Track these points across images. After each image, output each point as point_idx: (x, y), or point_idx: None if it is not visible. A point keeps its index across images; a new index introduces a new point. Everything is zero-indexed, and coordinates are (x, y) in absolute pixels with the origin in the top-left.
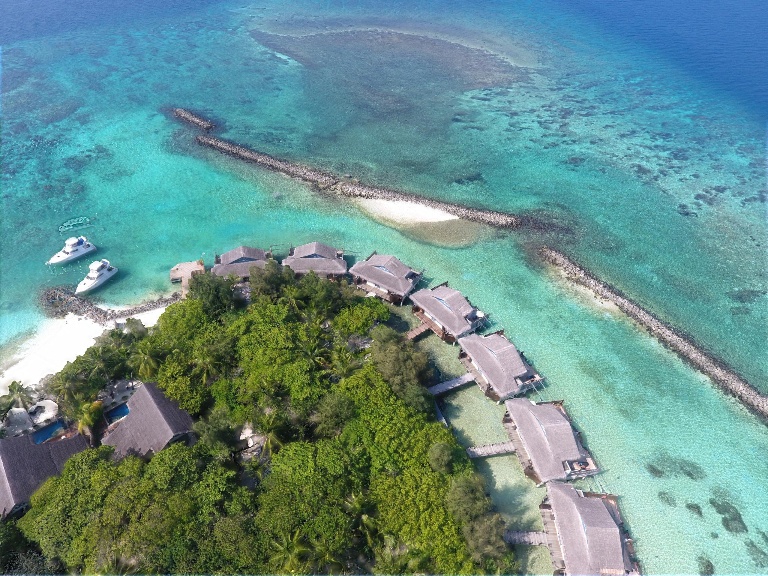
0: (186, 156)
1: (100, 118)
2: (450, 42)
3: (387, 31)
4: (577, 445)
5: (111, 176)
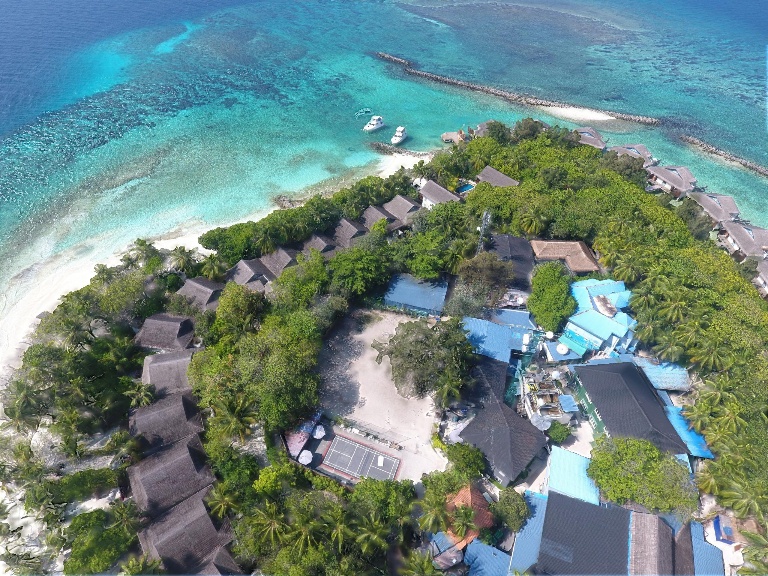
0: (404, 81)
1: (327, 58)
2: (561, 12)
3: (505, 4)
4: None
5: (362, 90)
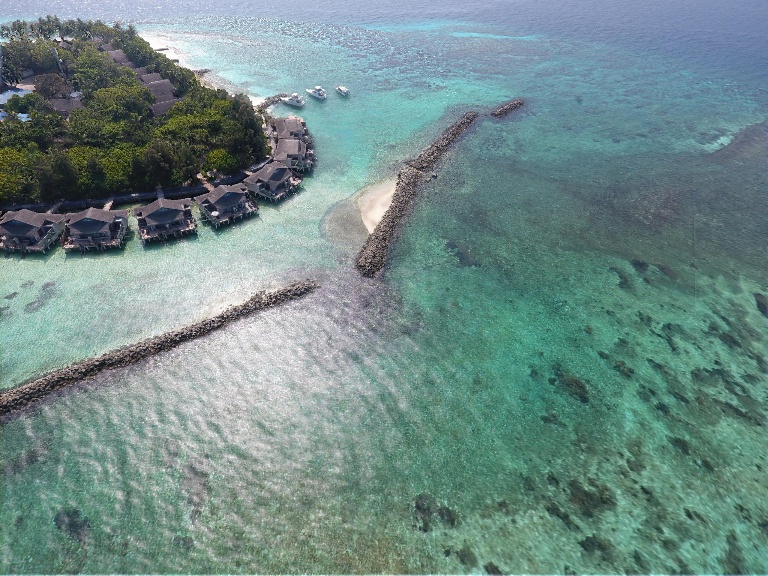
0: None
1: (489, 82)
2: None
3: None
4: (76, 228)
5: (406, 95)
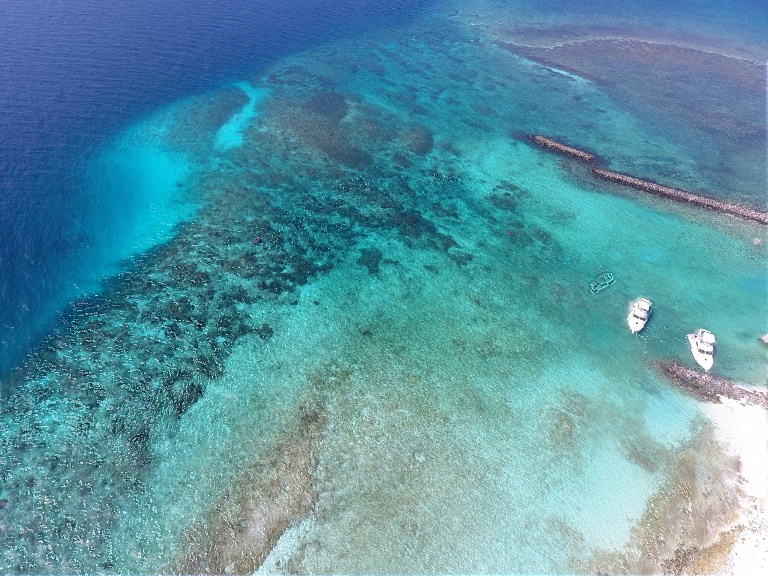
0: (604, 193)
1: (466, 148)
2: (706, 52)
3: (628, 40)
4: None
5: (557, 219)
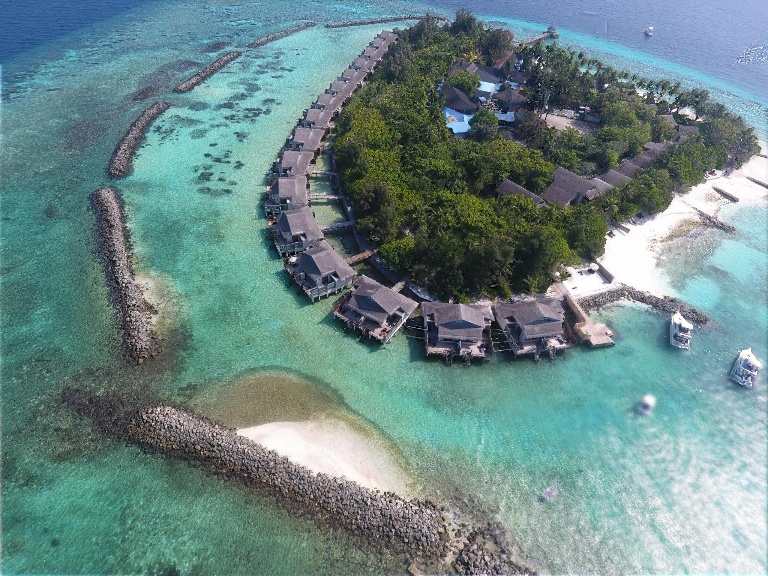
0: None
1: None
2: None
3: None
4: None
5: None
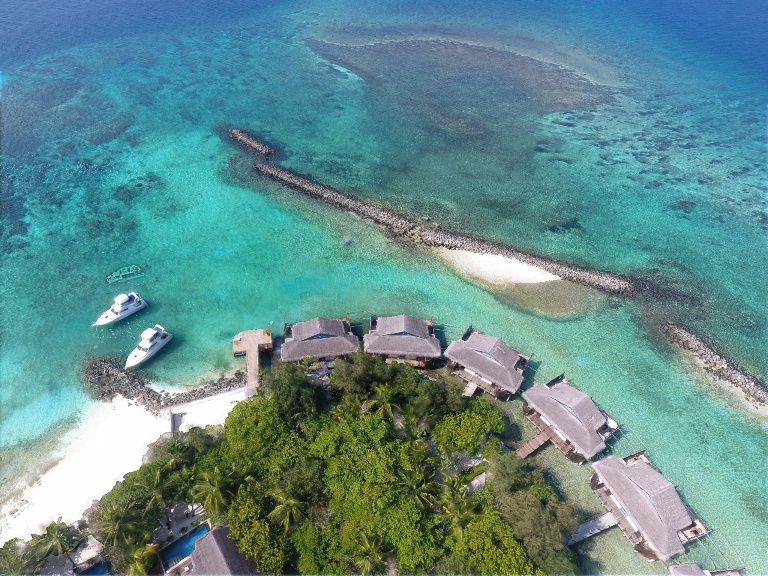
0: (244, 188)
1: (151, 139)
2: (520, 55)
3: (450, 41)
4: None
5: (164, 211)
